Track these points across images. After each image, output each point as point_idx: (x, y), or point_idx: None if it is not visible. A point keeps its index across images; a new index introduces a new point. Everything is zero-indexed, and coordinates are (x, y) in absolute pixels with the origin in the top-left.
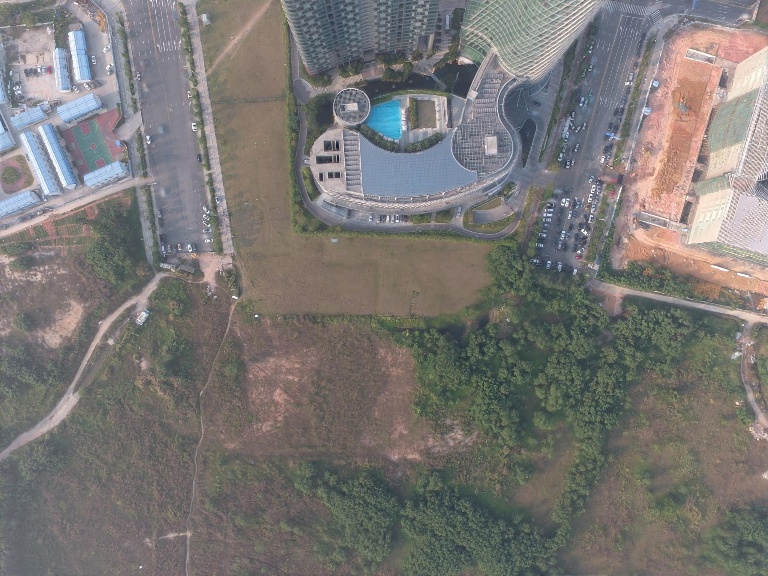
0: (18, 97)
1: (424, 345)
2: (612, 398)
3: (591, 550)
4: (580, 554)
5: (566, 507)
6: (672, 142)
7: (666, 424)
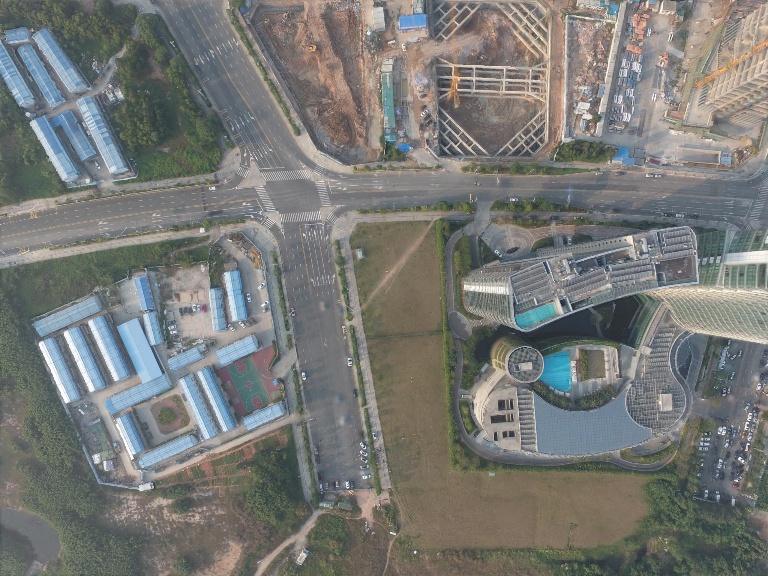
0: (173, 337)
1: None
2: None
3: None
4: None
5: None
6: None
7: None
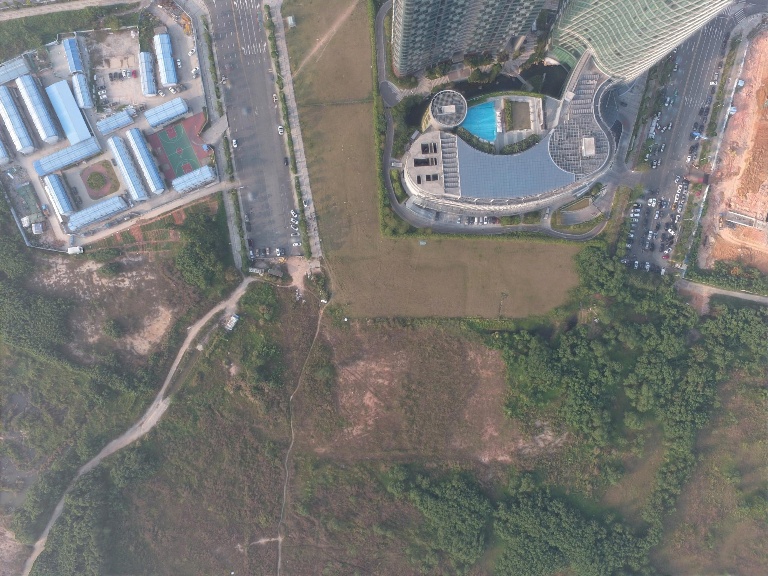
0: (103, 102)
1: (514, 347)
2: (702, 397)
3: (681, 549)
4: (670, 553)
5: (658, 506)
6: (757, 141)
7: (754, 422)
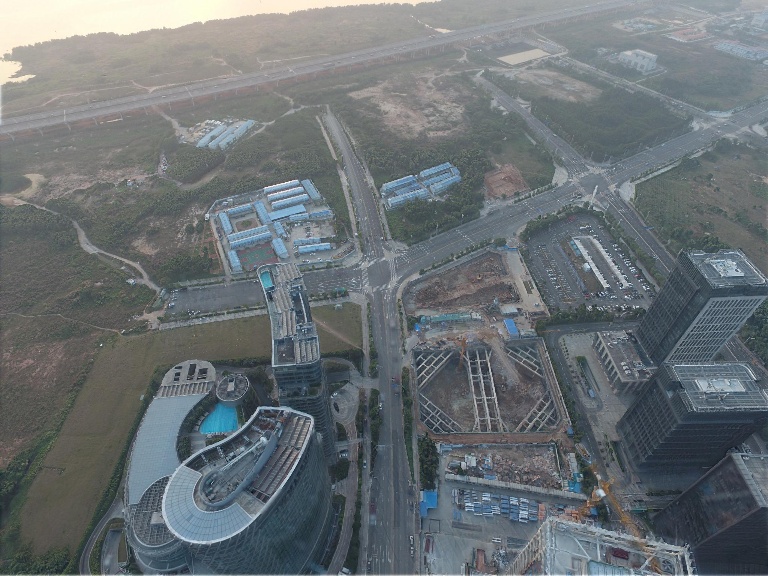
0: (293, 225)
1: (2, 480)
2: None
3: None
4: None
5: None
6: None
7: None
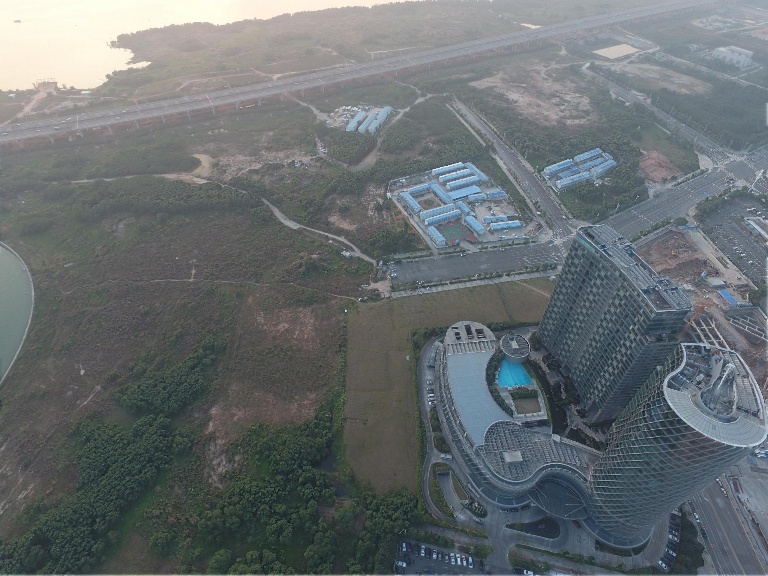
0: (474, 204)
1: None
2: None
3: None
4: None
5: None
6: None
7: None
